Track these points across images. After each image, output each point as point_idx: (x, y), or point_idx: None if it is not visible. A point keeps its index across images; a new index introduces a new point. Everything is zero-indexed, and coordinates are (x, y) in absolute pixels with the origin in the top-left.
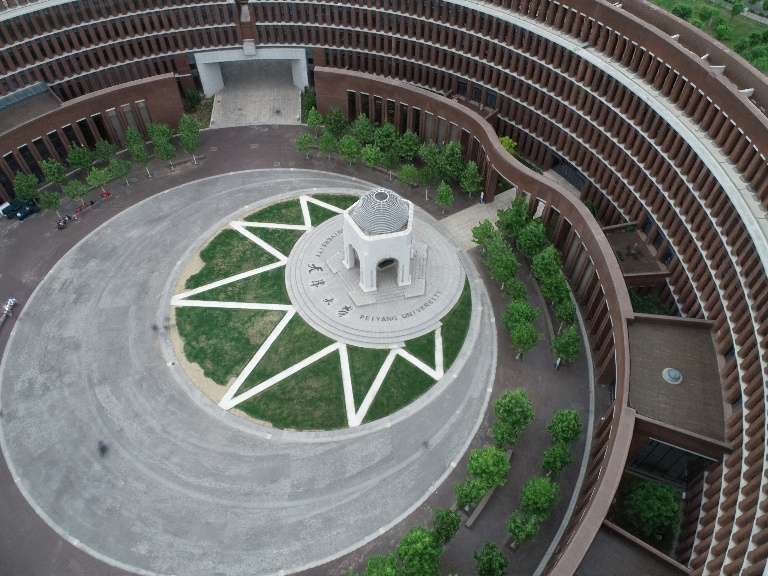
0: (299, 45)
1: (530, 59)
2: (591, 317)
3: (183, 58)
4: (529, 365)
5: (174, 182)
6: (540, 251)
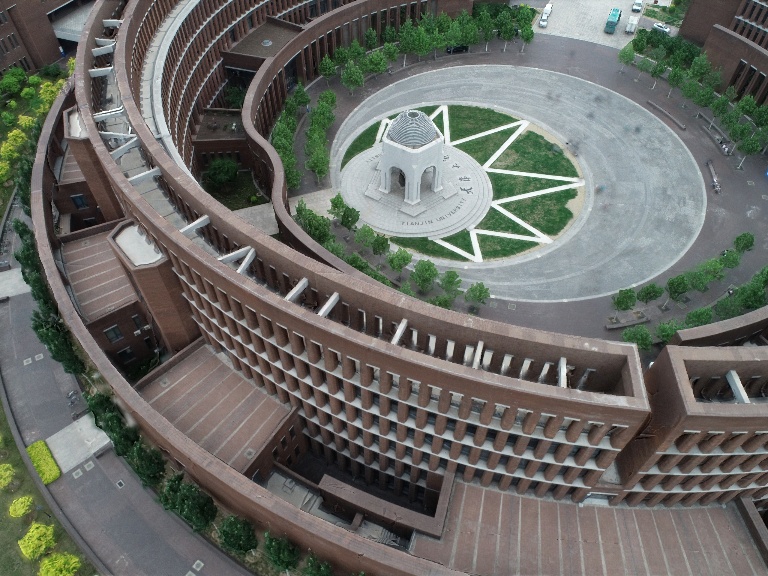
0: None
1: None
2: None
3: None
4: None
5: None
6: None
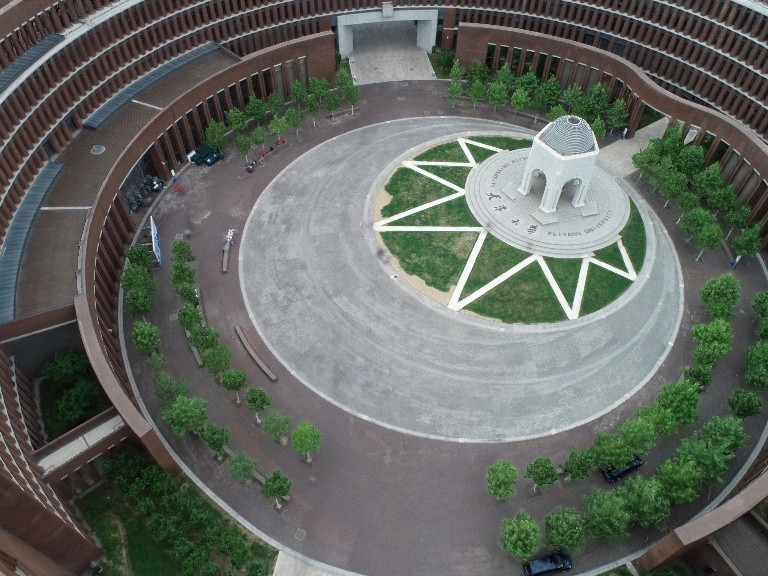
0: (433, 6)
1: (668, 6)
2: (753, 224)
3: (327, 20)
4: (709, 265)
5: (338, 130)
6: (699, 171)
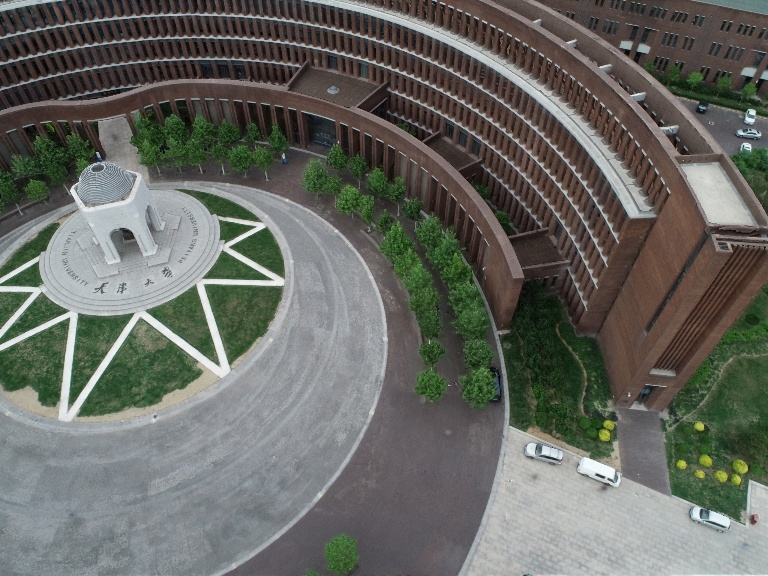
0: None
1: (5, 39)
2: None
3: None
4: (277, 176)
5: None
6: None
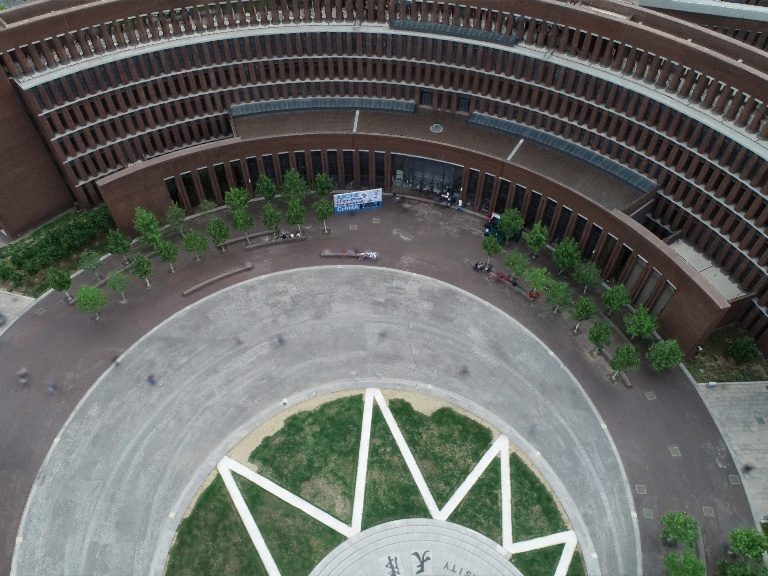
0: None
1: None
2: None
3: None
4: None
5: (571, 359)
6: None
